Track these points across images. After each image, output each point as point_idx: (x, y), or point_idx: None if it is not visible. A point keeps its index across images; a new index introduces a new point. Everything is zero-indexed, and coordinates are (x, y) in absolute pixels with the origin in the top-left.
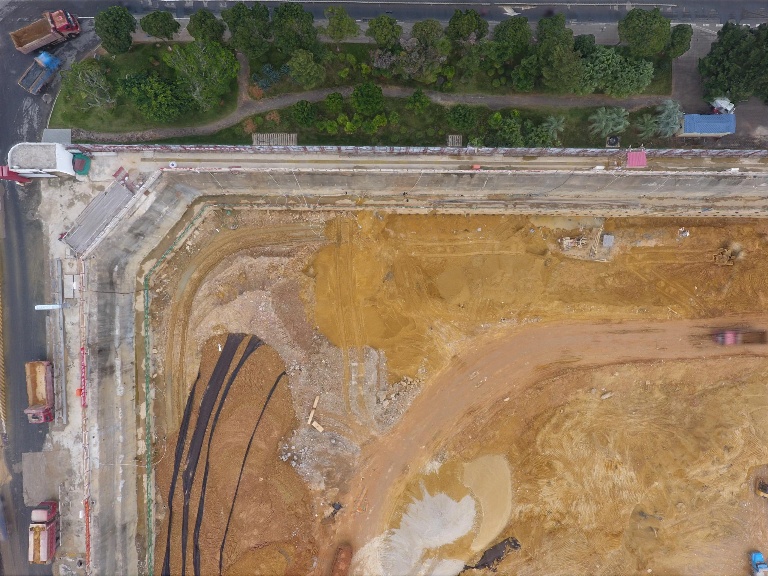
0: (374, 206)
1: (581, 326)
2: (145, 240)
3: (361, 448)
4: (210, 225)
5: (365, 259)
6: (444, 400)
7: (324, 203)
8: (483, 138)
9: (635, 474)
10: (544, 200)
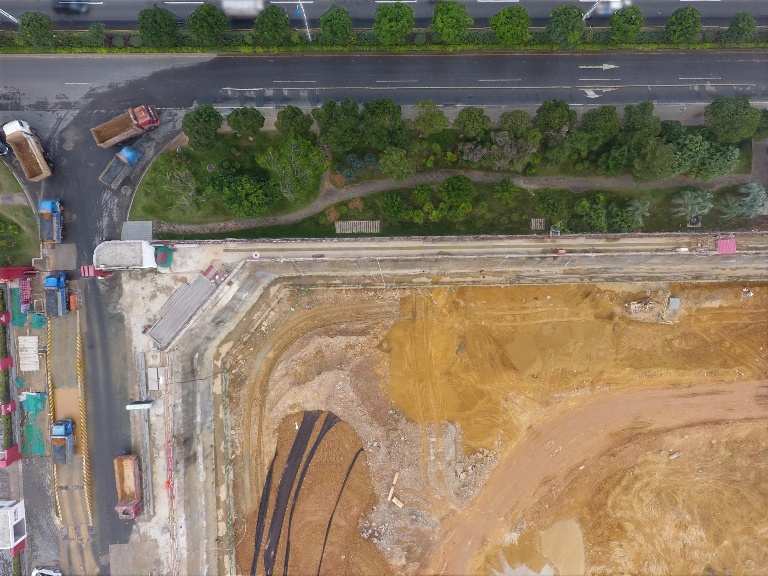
0: (452, 284)
1: (652, 391)
2: (224, 326)
3: (441, 522)
4: (285, 305)
5: (439, 333)
6: (521, 471)
7: (400, 282)
8: (566, 221)
9: (704, 533)
10: (619, 273)
